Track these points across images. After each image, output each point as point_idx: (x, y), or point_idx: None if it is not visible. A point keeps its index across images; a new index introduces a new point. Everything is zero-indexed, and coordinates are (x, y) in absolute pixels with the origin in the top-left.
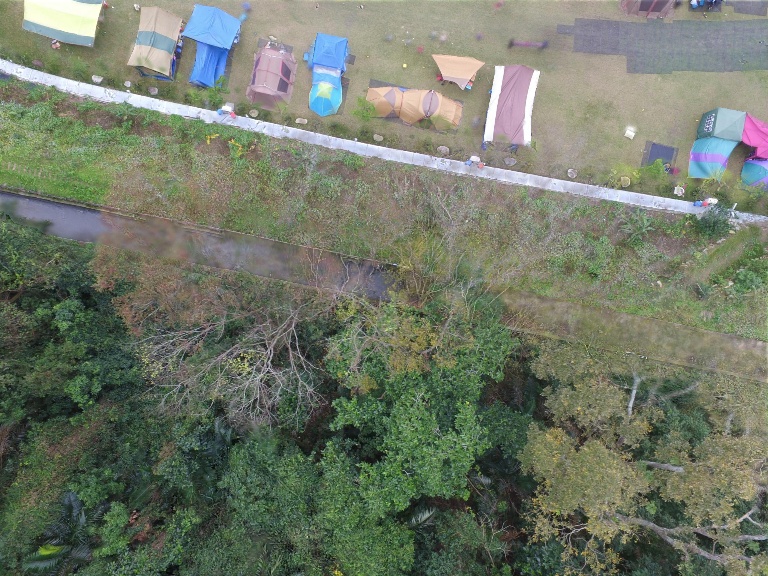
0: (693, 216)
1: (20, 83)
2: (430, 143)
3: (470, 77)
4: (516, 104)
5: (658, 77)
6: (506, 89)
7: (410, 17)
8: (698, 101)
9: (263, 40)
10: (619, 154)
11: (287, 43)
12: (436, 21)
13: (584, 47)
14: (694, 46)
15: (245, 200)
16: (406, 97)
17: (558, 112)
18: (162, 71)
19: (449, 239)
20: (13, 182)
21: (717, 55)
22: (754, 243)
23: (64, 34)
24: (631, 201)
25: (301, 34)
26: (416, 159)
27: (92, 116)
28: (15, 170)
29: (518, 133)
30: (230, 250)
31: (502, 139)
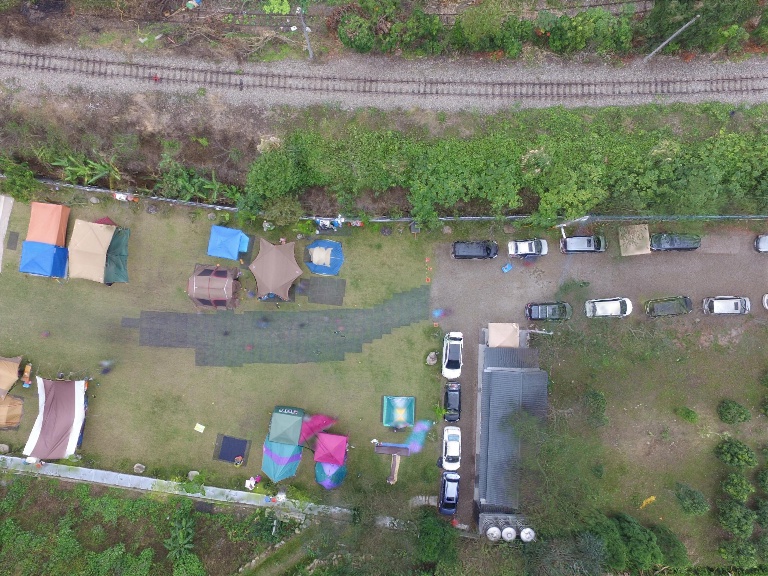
0: (262, 511)
1: None
2: None
3: (8, 389)
4: (62, 412)
5: (228, 370)
6: (48, 399)
7: None
8: (271, 393)
9: None
10: (189, 447)
11: None
12: None
13: (150, 340)
14: (266, 337)
15: None
16: None
17: (124, 406)
18: None
19: None
20: None
21: (290, 346)
22: (324, 539)
23: None
24: (202, 495)
25: None
26: None
27: None
28: None
29: (60, 444)
30: None
31: (40, 453)
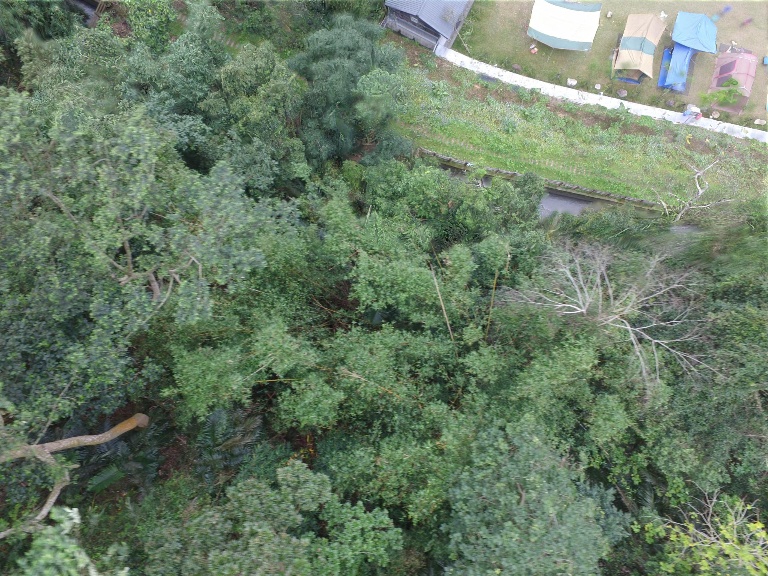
0: None
1: (506, 86)
2: None
3: None
4: None
5: None
6: None
7: None
8: None
9: (724, 45)
10: None
11: (747, 48)
12: None
13: None
14: None
15: (764, 196)
16: None
17: None
18: (649, 74)
19: None
20: (551, 178)
21: None
22: None
23: (555, 40)
24: None
25: (760, 39)
26: None
27: (581, 117)
28: (553, 167)
29: None
30: None
31: None
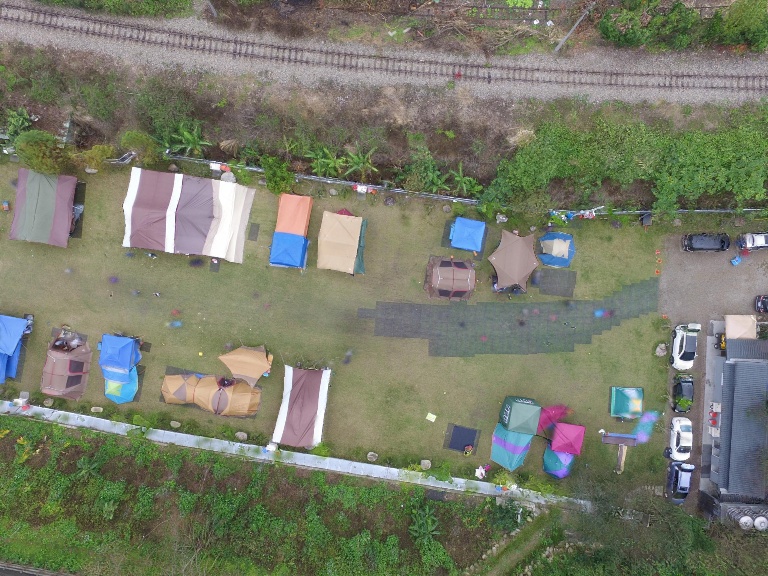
0: (493, 500)
1: None
2: (228, 429)
3: (258, 377)
4: (307, 400)
5: (460, 360)
6: (296, 387)
7: (207, 304)
8: (501, 383)
9: (57, 329)
10: (420, 436)
11: (81, 332)
12: (233, 307)
13: (385, 331)
14: (498, 328)
15: (14, 528)
16: (197, 392)
17: (358, 396)
18: None
19: (221, 562)
20: None
21: (521, 337)
22: (553, 527)
23: None
24: (432, 483)
25: (95, 323)
26: (214, 445)
27: None
28: None
29: (307, 432)
30: (2, 573)
31: (289, 441)
